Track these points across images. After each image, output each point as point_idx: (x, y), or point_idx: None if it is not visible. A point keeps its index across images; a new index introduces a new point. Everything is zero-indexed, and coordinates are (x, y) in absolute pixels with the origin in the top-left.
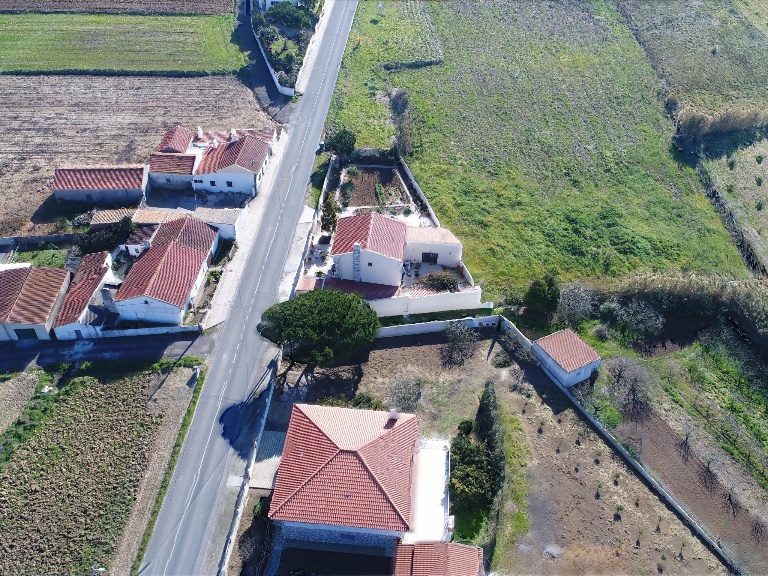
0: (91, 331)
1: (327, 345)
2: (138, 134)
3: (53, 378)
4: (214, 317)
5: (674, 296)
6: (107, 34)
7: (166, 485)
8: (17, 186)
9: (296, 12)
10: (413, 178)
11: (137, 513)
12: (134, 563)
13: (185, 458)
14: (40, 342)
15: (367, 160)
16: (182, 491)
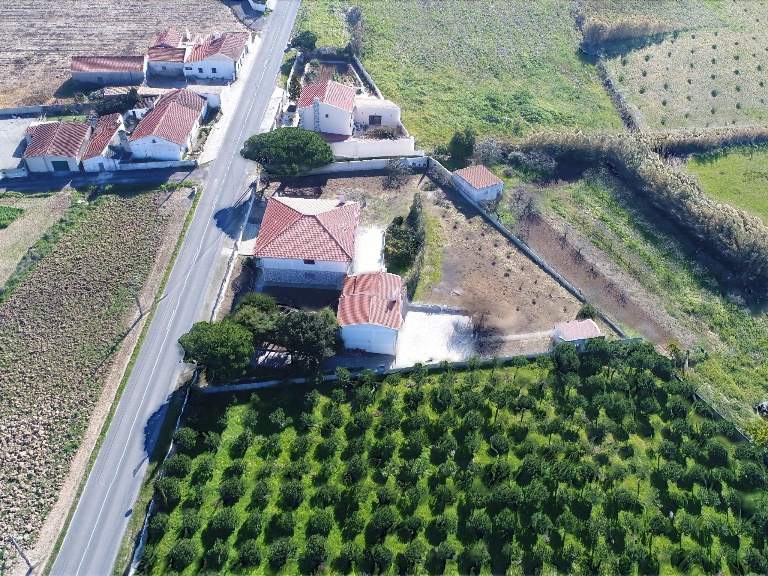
0: (111, 164)
1: (294, 162)
2: (136, 38)
3: (84, 195)
4: (206, 157)
5: (566, 147)
6: None
7: (176, 253)
8: (39, 74)
9: None
10: (364, 69)
11: (156, 269)
12: (157, 295)
13: (189, 239)
14: (72, 173)
15: (327, 57)
16: (189, 256)
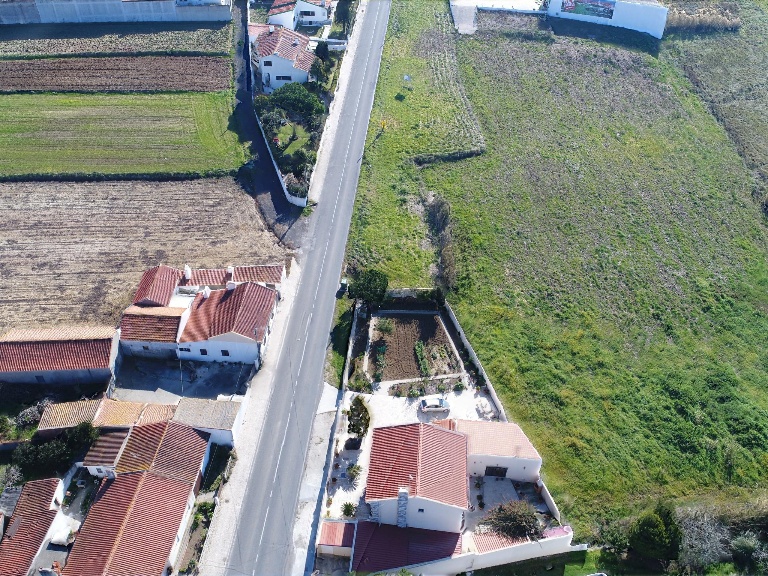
0: None
1: None
2: (110, 270)
3: None
4: None
5: None
6: (79, 121)
7: None
8: None
9: (307, 97)
10: (463, 333)
11: None
12: None
13: None
14: None
15: (401, 303)
16: None
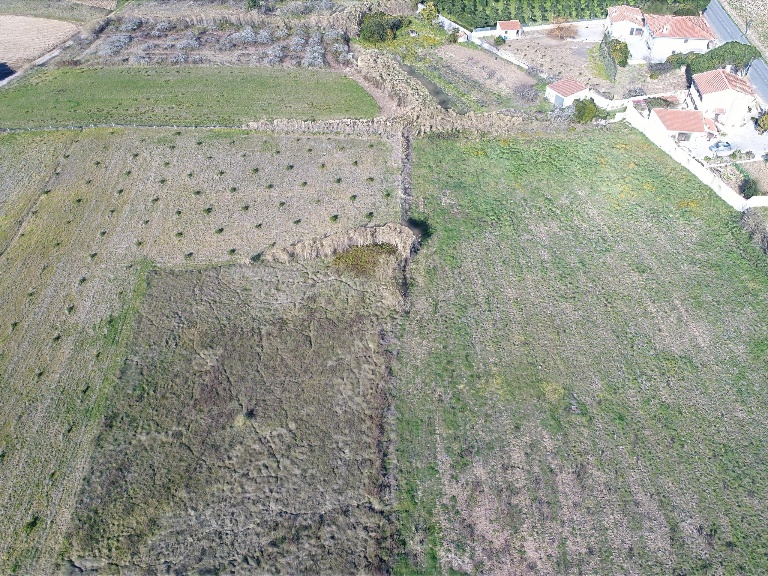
0: None
1: None
2: None
3: None
4: None
5: None
6: None
7: None
8: None
9: None
10: None
11: (761, 46)
12: None
13: None
14: None
15: None
16: None
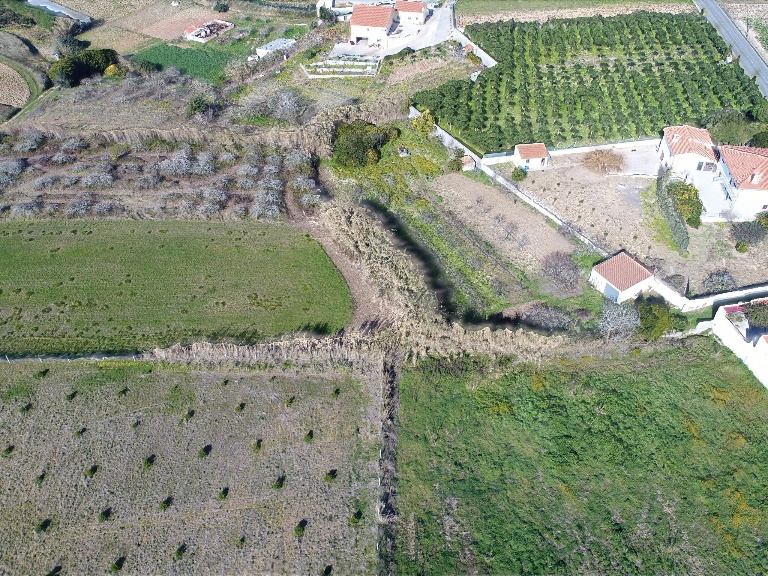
0: None
1: None
2: None
3: None
4: None
5: None
6: None
7: None
8: None
9: None
10: None
11: None
12: None
13: None
14: None
15: None
16: None
